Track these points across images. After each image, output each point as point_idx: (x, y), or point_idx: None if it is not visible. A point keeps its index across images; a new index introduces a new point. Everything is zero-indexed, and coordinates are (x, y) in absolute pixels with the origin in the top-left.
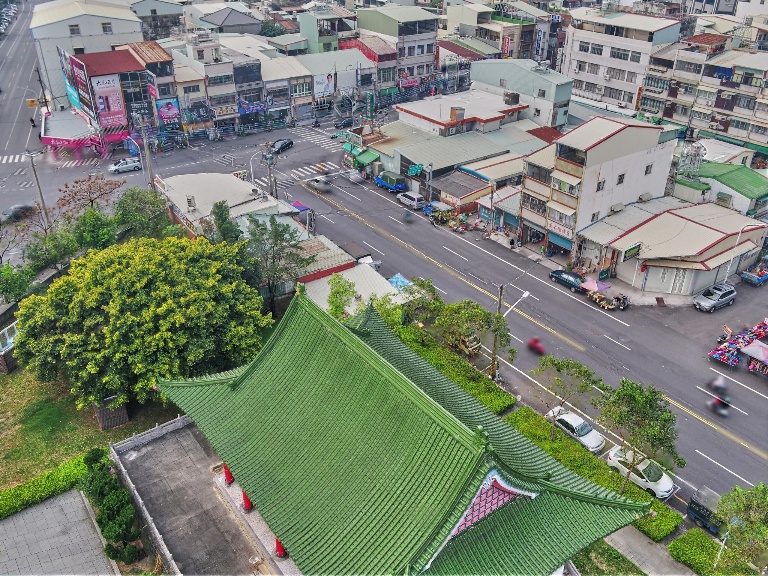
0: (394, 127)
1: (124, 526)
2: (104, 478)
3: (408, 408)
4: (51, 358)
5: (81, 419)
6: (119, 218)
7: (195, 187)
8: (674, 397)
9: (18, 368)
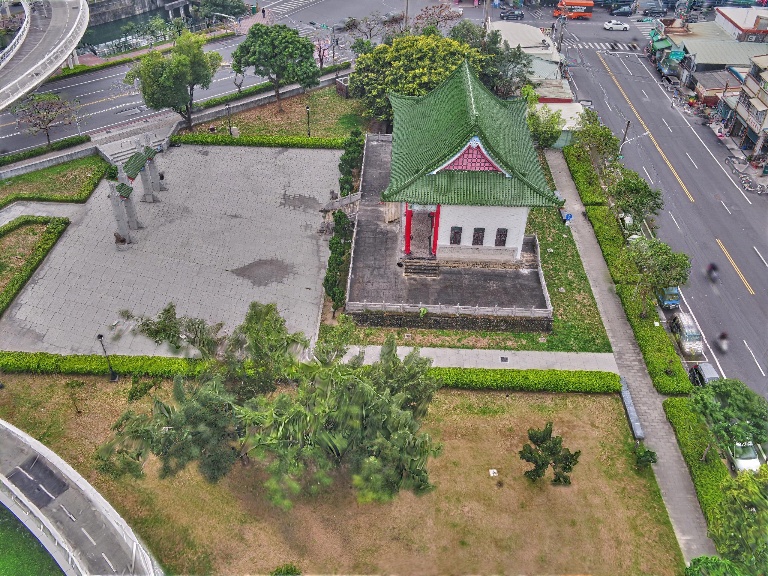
0: (704, 26)
1: (350, 158)
2: (354, 140)
3: (467, 111)
4: (360, 83)
5: (365, 127)
6: (449, 37)
7: (509, 31)
8: (726, 244)
9: (351, 98)
